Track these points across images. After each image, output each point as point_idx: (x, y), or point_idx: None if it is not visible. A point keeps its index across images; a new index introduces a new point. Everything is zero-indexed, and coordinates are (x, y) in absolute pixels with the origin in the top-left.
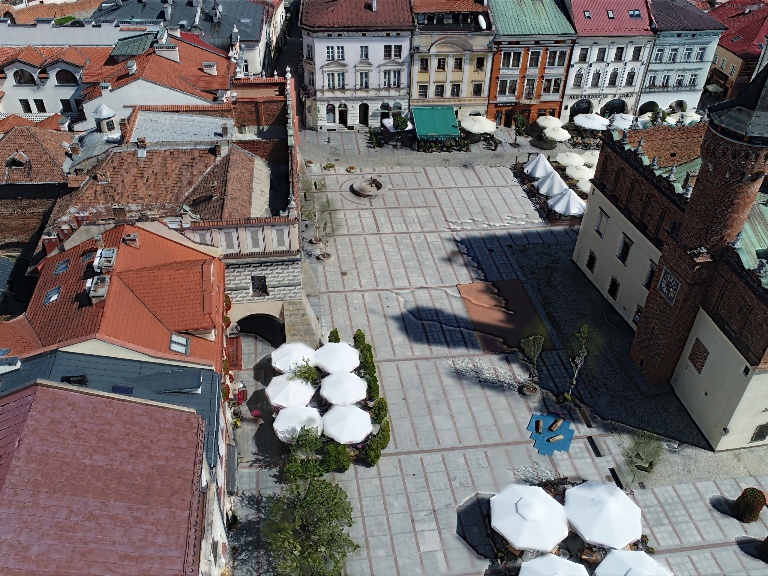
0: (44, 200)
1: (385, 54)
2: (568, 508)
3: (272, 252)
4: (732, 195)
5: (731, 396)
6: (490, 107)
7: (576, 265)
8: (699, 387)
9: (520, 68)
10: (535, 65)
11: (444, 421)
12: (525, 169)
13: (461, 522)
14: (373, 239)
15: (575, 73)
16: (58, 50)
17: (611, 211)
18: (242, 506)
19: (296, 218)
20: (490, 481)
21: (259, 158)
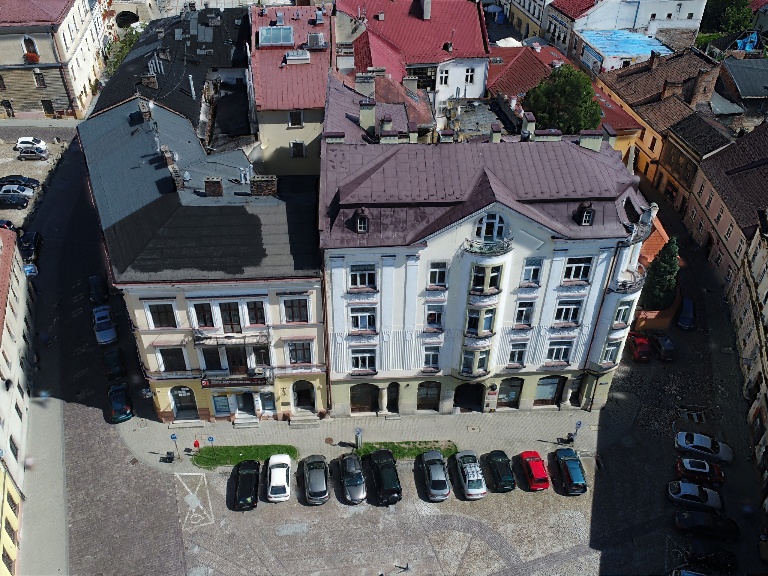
0: None
1: None
2: None
3: None
4: None
5: None
6: None
7: None
8: None
9: None
10: None
11: None
12: None
13: None
14: (197, 7)
15: None
16: None
17: None
18: None
19: None
20: None
21: None
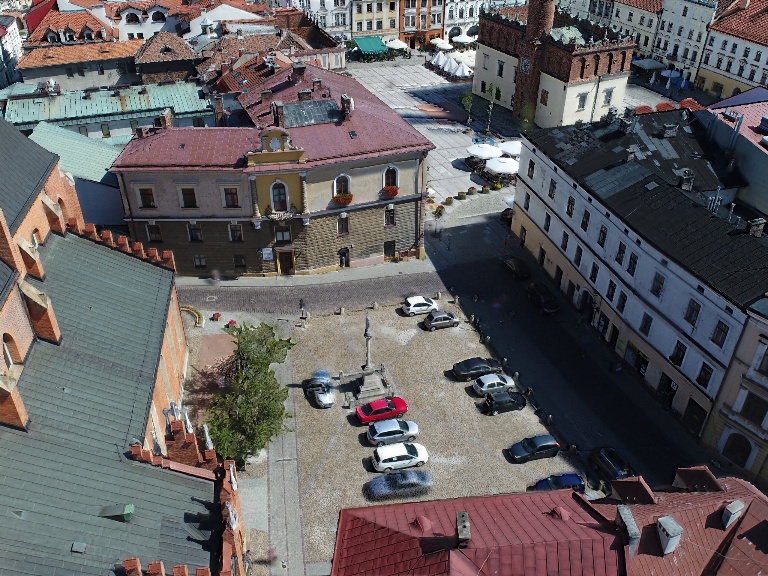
0: (183, 72)
1: (335, 3)
2: (500, 147)
3: (333, 69)
4: (545, 8)
5: (561, 104)
6: (401, 35)
7: (475, 95)
8: (547, 113)
9: (416, 8)
10: (425, 6)
11: None
12: (432, 62)
13: (454, 165)
14: None
15: (449, 10)
16: (148, 2)
17: (490, 52)
18: None
19: None
20: (462, 155)
21: (302, 39)
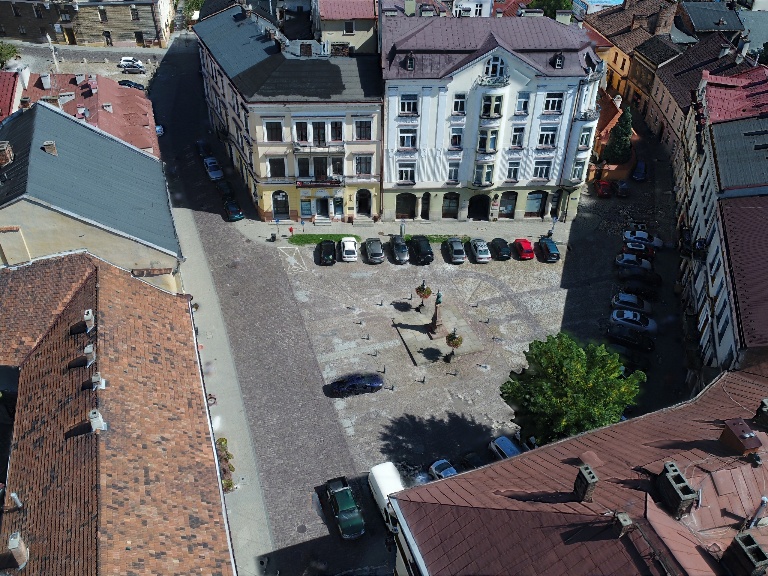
0: None
1: None
2: None
3: None
4: None
5: None
6: None
7: None
8: None
9: None
10: None
11: None
12: None
13: None
14: None
15: None
16: None
17: None
18: (179, 8)
19: None
20: None
21: None
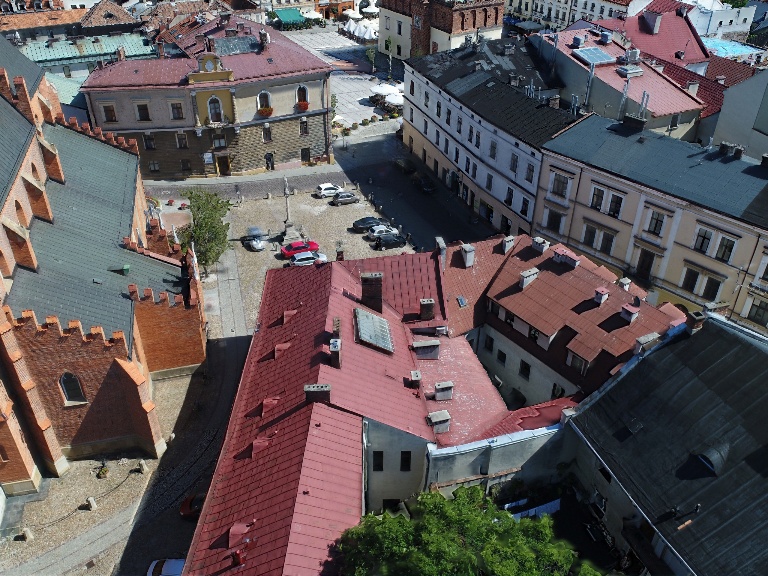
0: None
1: None
2: None
3: None
4: None
5: None
6: (316, 7)
7: (381, 53)
8: None
9: None
10: None
11: (343, 88)
12: (344, 28)
13: (361, 103)
14: None
15: None
16: None
17: (390, 14)
18: None
19: (264, 9)
20: (367, 96)
21: (227, 5)
